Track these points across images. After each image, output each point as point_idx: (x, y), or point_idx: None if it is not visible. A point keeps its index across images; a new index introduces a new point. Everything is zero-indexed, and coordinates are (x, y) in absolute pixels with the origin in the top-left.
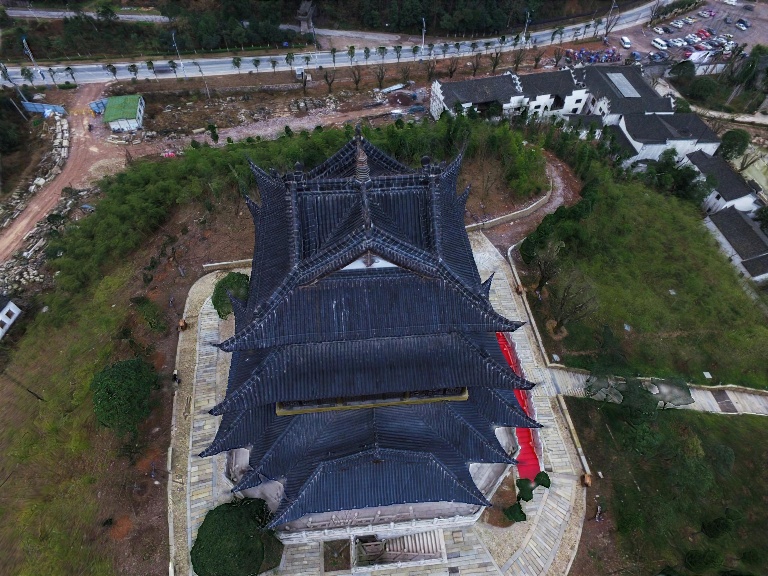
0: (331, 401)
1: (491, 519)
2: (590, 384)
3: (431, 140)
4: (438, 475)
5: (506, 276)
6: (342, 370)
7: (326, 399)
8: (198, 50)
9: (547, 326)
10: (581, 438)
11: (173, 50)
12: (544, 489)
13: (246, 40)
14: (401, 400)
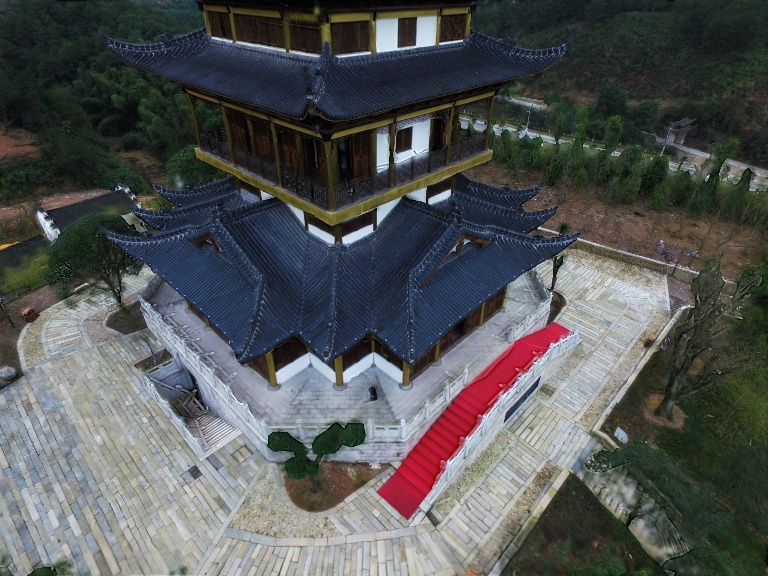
0: (229, 156)
1: (292, 477)
2: (663, 531)
3: (681, 174)
4: (249, 309)
5: (649, 323)
6: (214, 67)
7: (225, 149)
8: (552, 131)
9: (651, 398)
10: (535, 539)
11: (532, 125)
12: (395, 527)
13: (600, 133)
14: (274, 185)
